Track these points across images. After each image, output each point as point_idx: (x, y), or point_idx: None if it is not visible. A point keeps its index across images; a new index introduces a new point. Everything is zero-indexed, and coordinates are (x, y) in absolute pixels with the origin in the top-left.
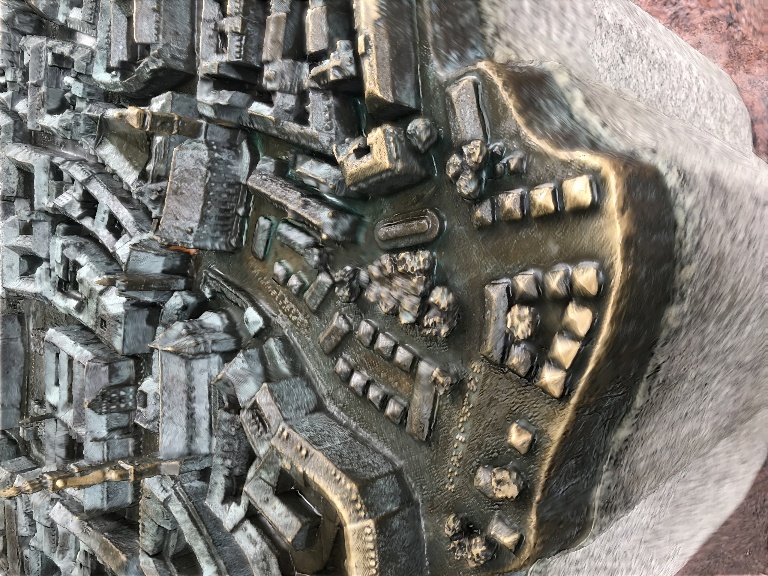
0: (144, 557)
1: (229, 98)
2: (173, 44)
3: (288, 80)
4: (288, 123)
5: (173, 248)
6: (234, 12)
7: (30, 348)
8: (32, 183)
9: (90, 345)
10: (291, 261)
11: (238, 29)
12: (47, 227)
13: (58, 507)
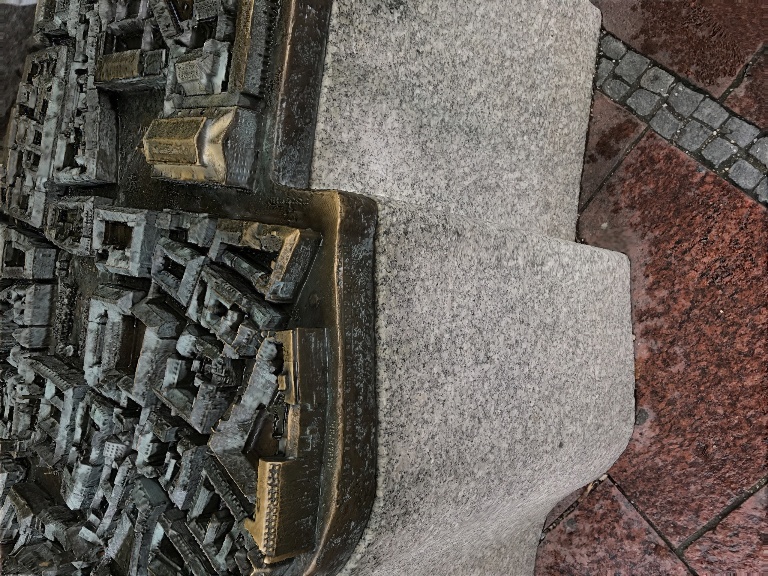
0: None
1: None
2: None
3: None
4: None
5: None
6: None
7: None
8: None
9: None
10: None
11: None
12: None
13: None
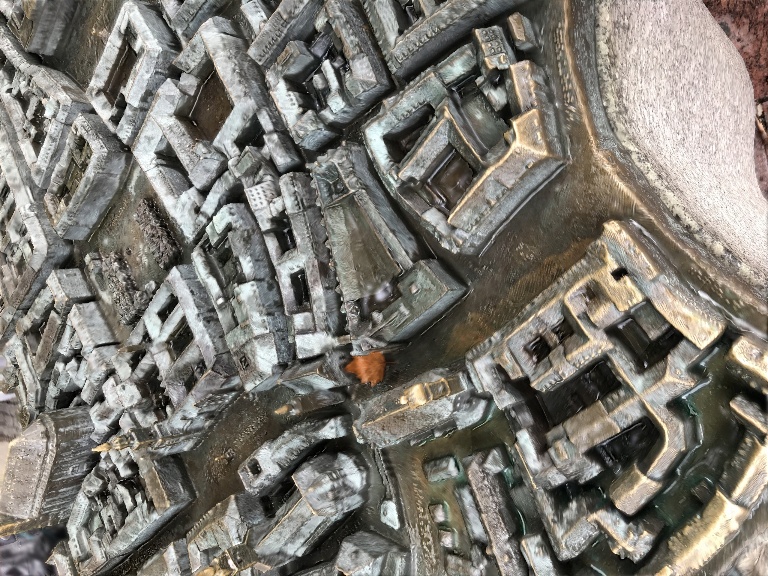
0: (193, 545)
1: (506, 405)
2: (480, 232)
3: (573, 469)
4: (544, 495)
5: (349, 370)
6: (574, 362)
7: (126, 190)
8: (211, 66)
9: (212, 324)
10: (454, 514)
11: (564, 377)
12: (215, 165)
13: (112, 385)
